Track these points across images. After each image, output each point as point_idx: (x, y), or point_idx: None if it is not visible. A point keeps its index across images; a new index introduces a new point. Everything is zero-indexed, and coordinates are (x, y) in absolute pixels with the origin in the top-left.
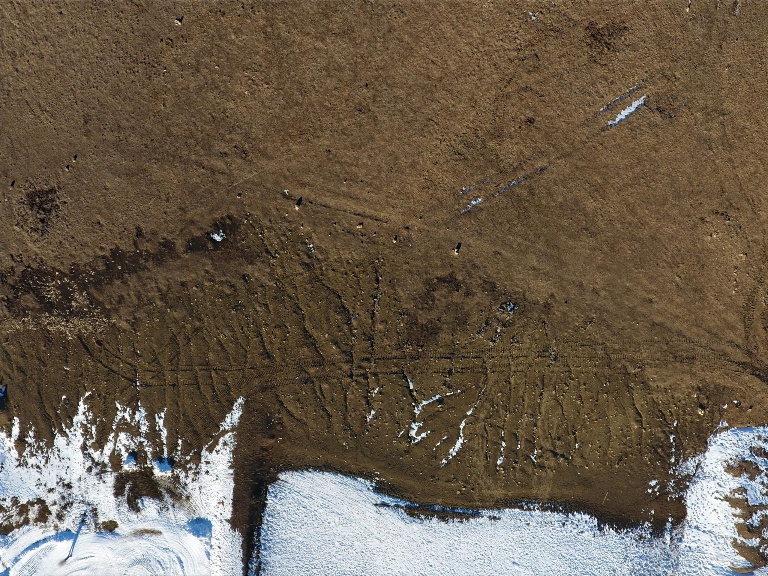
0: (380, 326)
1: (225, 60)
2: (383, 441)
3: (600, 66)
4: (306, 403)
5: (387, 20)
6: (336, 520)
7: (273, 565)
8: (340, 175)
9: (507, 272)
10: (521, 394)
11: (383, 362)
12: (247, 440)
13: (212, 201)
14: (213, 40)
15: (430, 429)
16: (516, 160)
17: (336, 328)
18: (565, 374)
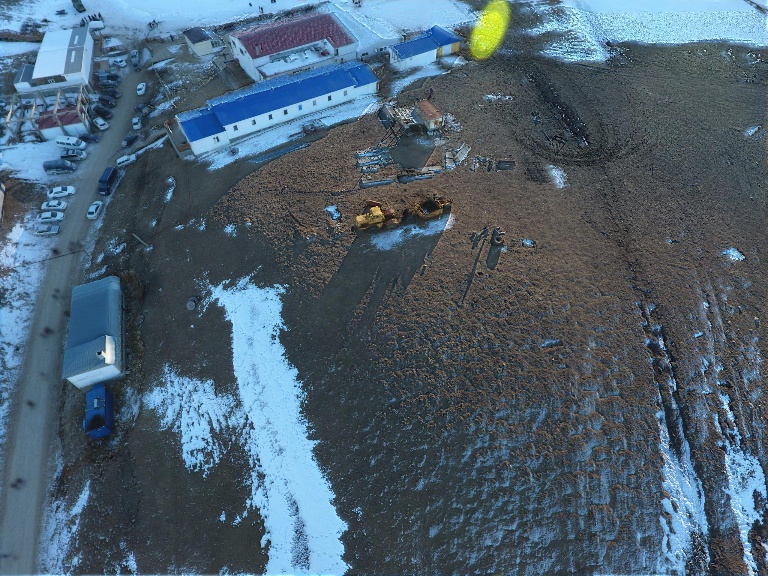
0: None
1: None
2: (766, 53)
3: None
4: None
5: None
6: None
7: None
8: None
9: (762, 88)
10: None
11: None
12: None
13: None
14: None
15: None
16: None
17: None
18: None
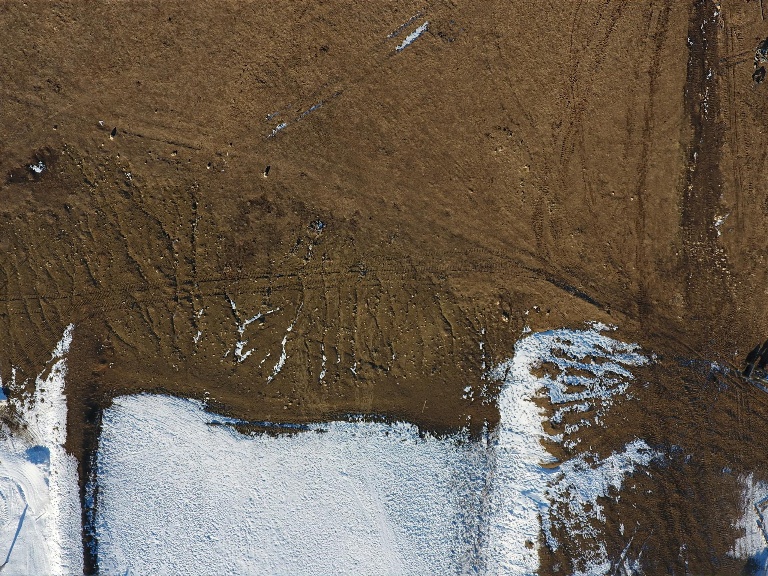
0: (200, 249)
1: None
2: (211, 361)
3: None
4: (134, 327)
5: None
6: (170, 441)
7: (111, 488)
8: (151, 105)
9: (314, 192)
10: (336, 309)
11: (205, 284)
12: (78, 365)
13: (29, 133)
14: None
15: (254, 347)
16: (314, 86)
17: (158, 253)
18: (375, 287)
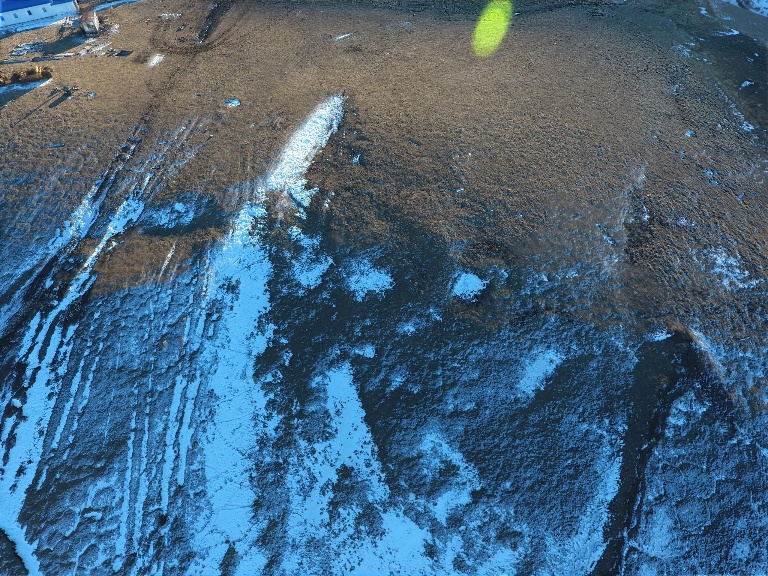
0: (443, 5)
1: None
2: None
3: None
4: None
5: None
6: None
7: None
8: None
9: None
10: None
11: None
12: None
13: None
14: None
15: None
16: None
17: None
18: None
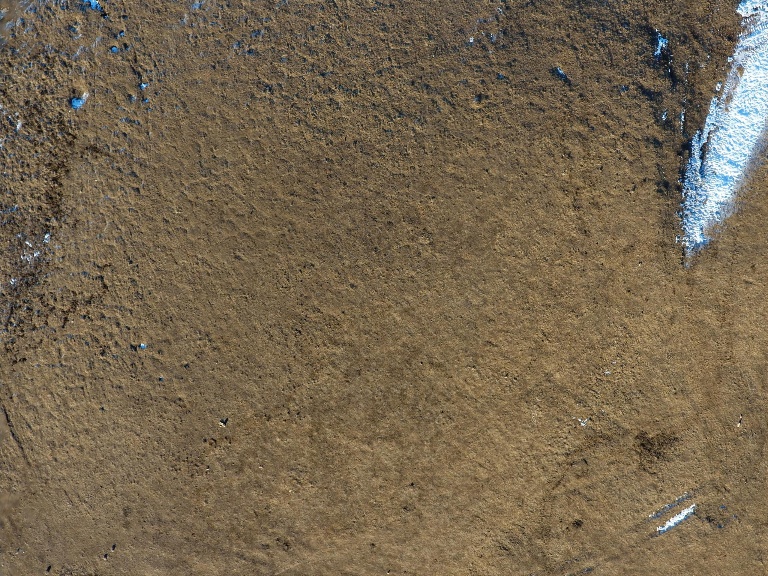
0: None
1: (269, 461)
2: None
3: (649, 474)
4: None
5: (435, 425)
6: None
7: None
8: (383, 566)
9: None
10: None
11: None
12: None
13: None
14: (258, 442)
15: None
16: (563, 559)
17: None
18: None
